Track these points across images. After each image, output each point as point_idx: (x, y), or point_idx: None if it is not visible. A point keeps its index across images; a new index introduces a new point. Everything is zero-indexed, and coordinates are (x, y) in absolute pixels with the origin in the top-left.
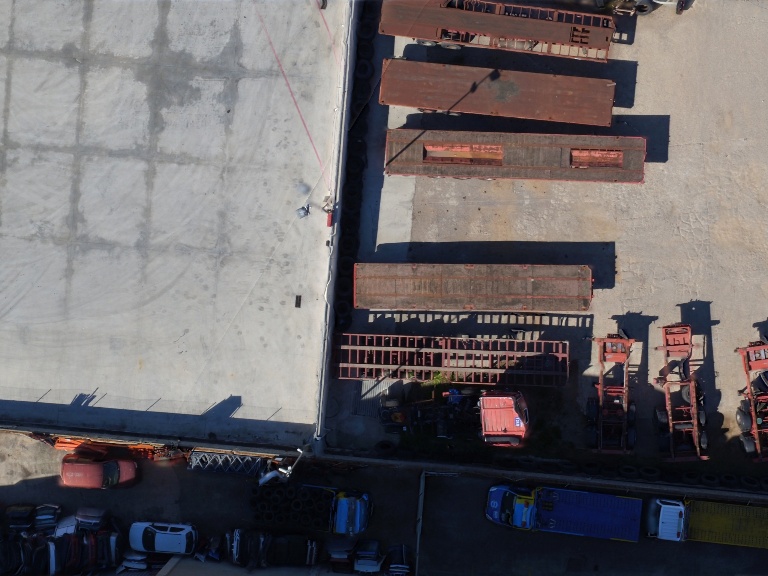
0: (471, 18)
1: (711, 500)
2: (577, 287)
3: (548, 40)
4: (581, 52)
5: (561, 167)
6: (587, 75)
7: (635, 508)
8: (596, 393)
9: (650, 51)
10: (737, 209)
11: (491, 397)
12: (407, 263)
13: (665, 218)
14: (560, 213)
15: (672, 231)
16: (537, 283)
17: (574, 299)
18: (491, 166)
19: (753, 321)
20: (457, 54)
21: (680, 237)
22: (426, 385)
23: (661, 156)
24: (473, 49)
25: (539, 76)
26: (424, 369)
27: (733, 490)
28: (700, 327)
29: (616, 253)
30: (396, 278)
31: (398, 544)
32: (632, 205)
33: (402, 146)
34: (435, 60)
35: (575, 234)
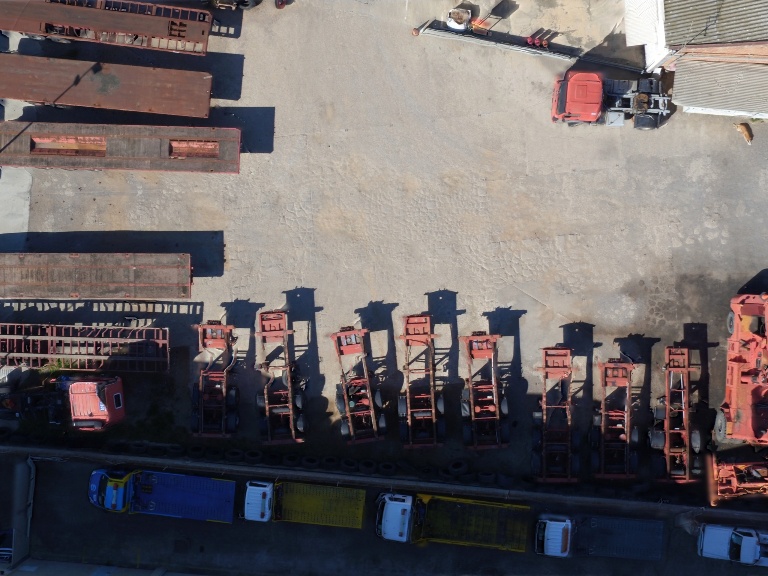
0: (73, 12)
1: (303, 481)
2: (177, 275)
3: (147, 34)
4: (180, 45)
5: (160, 158)
6: (185, 68)
7: (229, 490)
8: (198, 378)
9: (256, 45)
10: (339, 198)
11: (78, 382)
12: (15, 252)
13: (271, 207)
14: (171, 203)
15: (278, 220)
16: (139, 271)
17: (174, 287)
18: (94, 157)
19: (355, 307)
20: (70, 48)
21: (286, 226)
22: (44, 372)
23: (267, 147)
24: (85, 43)
25: (139, 69)
26: (31, 356)
27: (328, 472)
28: (303, 313)
29: (225, 242)
30: (4, 267)
31: (8, 528)
32: (240, 195)
33: (10, 138)
34: (45, 54)
35: (186, 223)
